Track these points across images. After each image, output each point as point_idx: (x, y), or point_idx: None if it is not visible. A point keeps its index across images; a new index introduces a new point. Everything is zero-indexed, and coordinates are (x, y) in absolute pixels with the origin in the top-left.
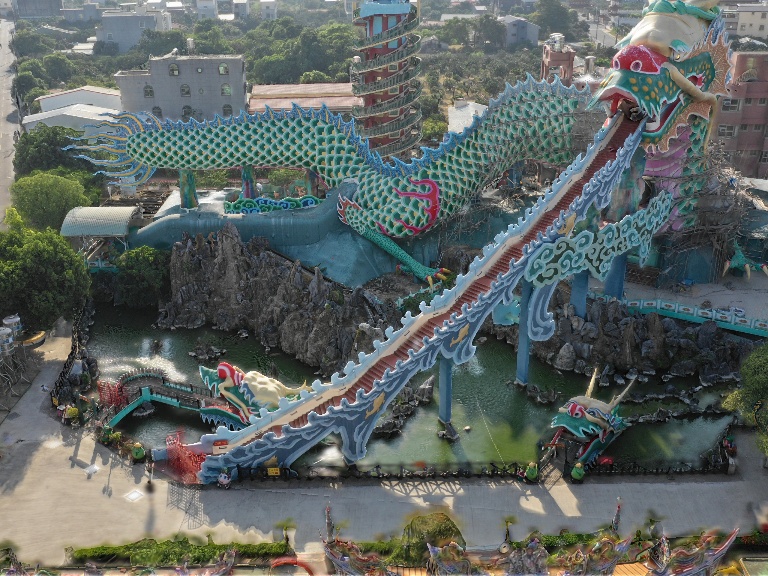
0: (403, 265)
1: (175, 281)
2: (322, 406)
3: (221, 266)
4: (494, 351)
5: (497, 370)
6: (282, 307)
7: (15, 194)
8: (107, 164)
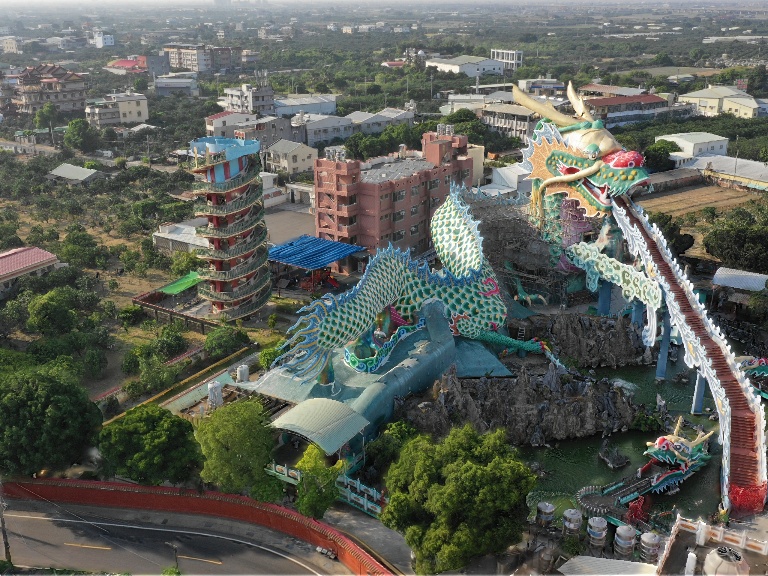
0: (509, 348)
1: (444, 438)
2: (734, 423)
3: (465, 404)
4: (608, 374)
5: (638, 380)
6: (541, 407)
7: (220, 446)
8: (300, 364)
